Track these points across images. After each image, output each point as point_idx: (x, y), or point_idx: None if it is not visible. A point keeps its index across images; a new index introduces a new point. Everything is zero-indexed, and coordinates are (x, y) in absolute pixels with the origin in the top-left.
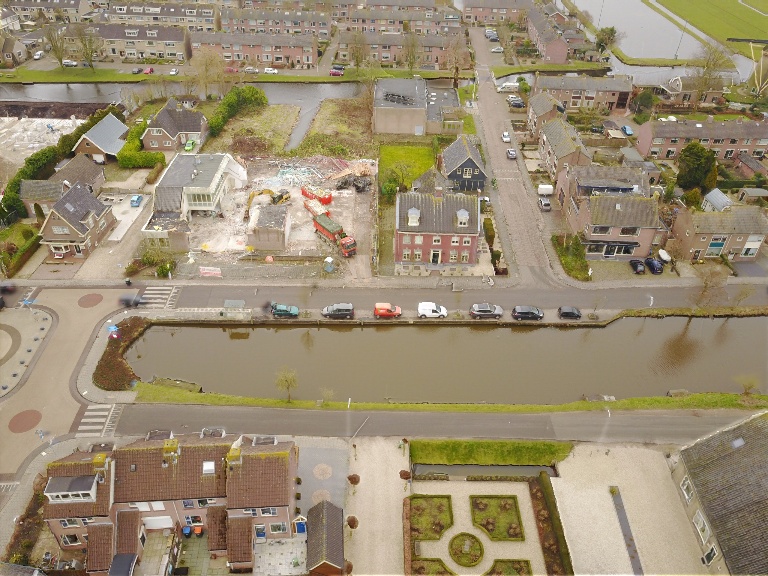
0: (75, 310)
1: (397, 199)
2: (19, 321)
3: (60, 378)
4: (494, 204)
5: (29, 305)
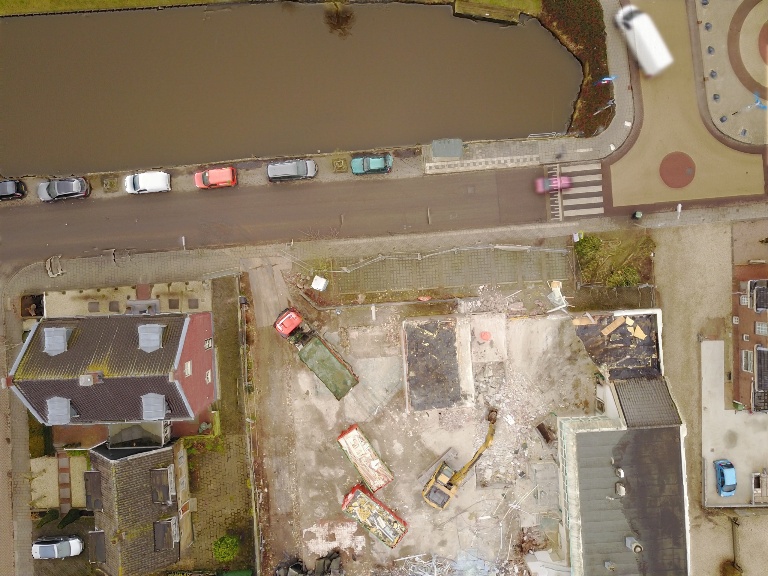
0: (690, 144)
1: (178, 362)
2: (759, 111)
3: (644, 4)
4: (28, 551)
5: (765, 152)
